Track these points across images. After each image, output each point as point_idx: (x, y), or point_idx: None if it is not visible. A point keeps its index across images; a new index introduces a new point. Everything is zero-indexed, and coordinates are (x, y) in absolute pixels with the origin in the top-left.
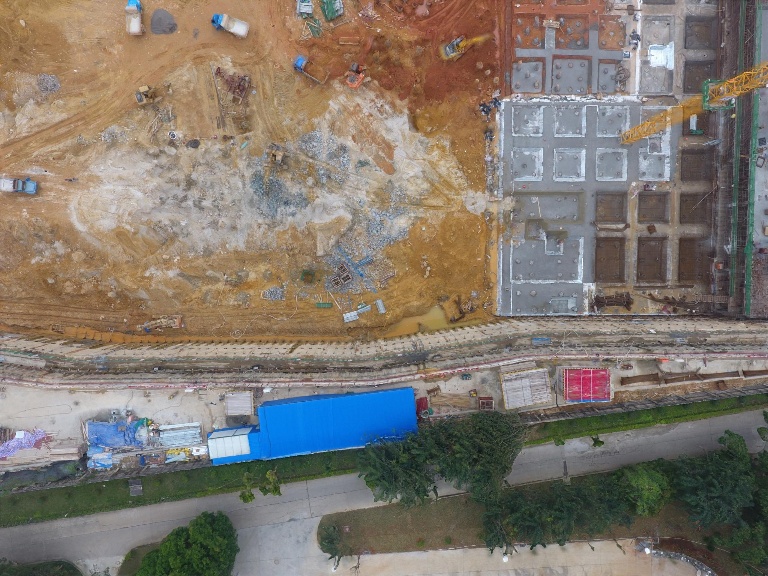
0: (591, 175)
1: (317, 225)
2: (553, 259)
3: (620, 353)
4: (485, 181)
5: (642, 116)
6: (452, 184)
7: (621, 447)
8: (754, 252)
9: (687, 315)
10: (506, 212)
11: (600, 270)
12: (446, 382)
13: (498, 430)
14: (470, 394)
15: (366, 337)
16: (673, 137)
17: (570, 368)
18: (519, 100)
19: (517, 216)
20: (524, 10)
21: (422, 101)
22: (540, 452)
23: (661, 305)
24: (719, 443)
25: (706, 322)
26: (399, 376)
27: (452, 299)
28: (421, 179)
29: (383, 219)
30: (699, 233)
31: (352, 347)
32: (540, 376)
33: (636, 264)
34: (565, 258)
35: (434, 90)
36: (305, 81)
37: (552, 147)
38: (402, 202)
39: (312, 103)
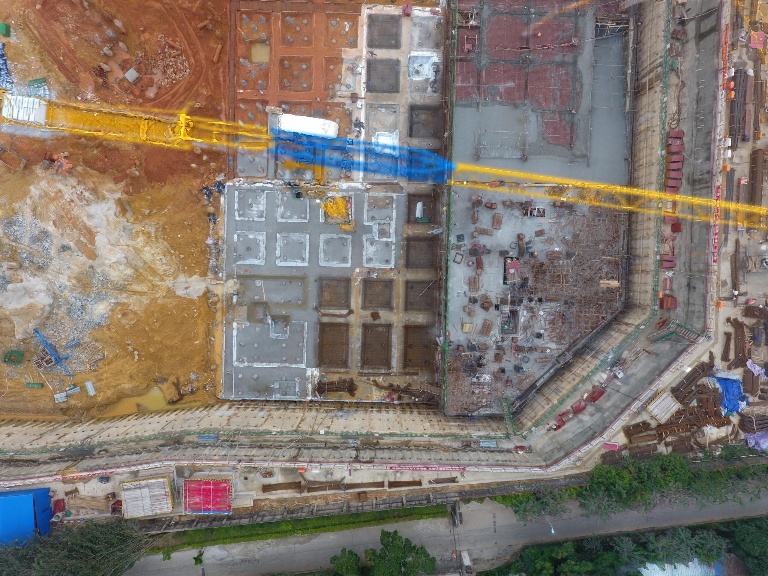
0: (314, 260)
1: (7, 311)
2: (278, 342)
3: (263, 460)
4: (206, 264)
5: (368, 202)
6: (156, 270)
7: (261, 555)
8: (452, 349)
9: (410, 403)
10: (229, 295)
11: (326, 354)
12: (85, 484)
13: (106, 542)
14: (107, 497)
15: (82, 417)
16: (398, 224)
17: (190, 479)
18: (242, 184)
19: (241, 299)
20: (247, 96)
21: (144, 183)
22: (178, 558)
23: (386, 392)
24: (330, 563)
25: (411, 415)
26: (37, 477)
27: (171, 381)
28: (124, 265)
29: (84, 304)
30: (423, 321)
31: (44, 433)
32: (160, 486)
33: (360, 350)
34: (290, 342)
35: (153, 173)
36: (7, 166)
37: (275, 232)
38: (105, 287)
39: (13, 188)
